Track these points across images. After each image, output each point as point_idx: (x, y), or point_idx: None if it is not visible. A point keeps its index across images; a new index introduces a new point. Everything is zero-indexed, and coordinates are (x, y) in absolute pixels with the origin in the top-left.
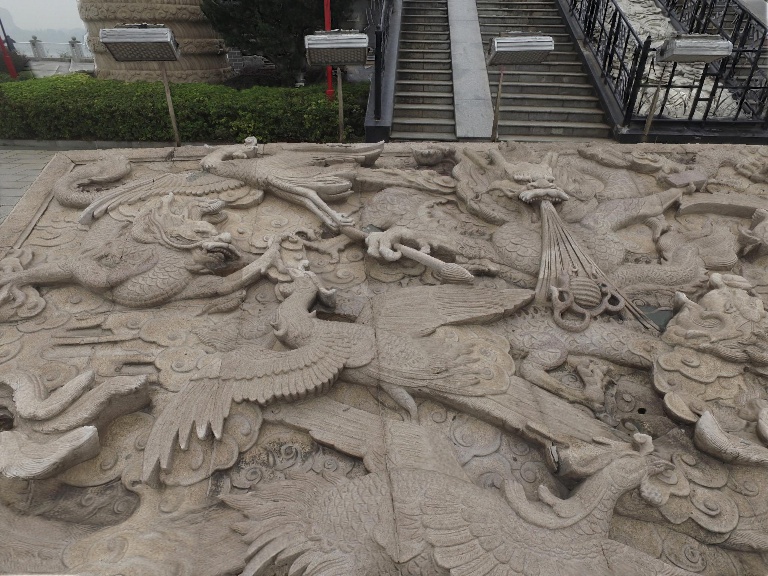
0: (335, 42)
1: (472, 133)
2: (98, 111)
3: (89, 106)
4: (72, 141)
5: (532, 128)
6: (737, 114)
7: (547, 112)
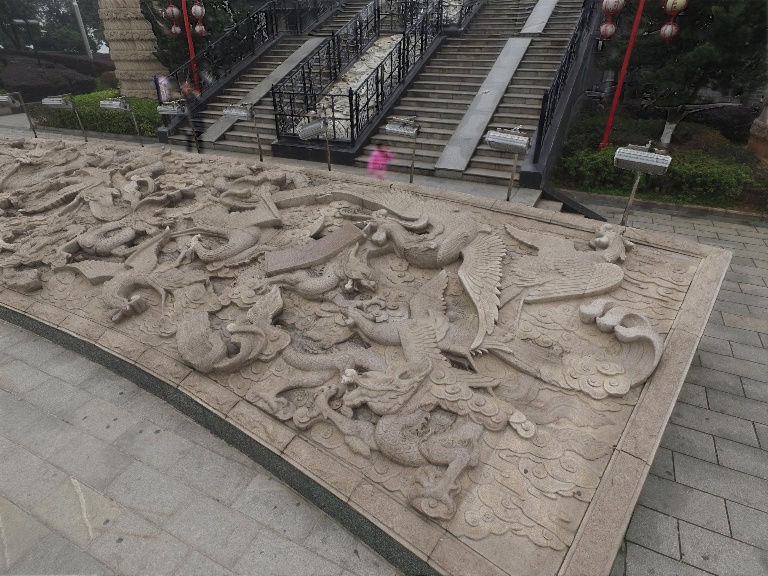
0: None
1: (204, 138)
2: (85, 114)
3: (84, 111)
4: (80, 130)
5: (243, 137)
6: (334, 135)
7: (261, 128)
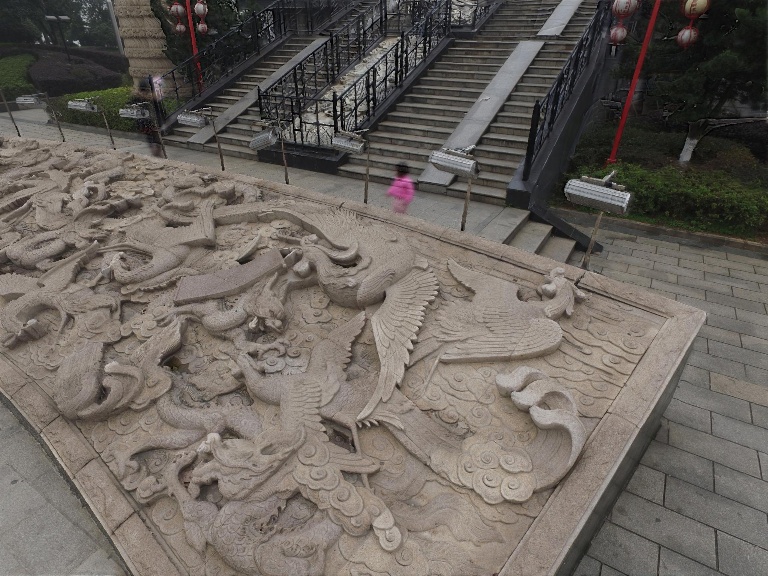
0: None
1: (194, 140)
2: None
3: None
4: (91, 127)
5: (233, 140)
6: (319, 142)
7: (252, 131)
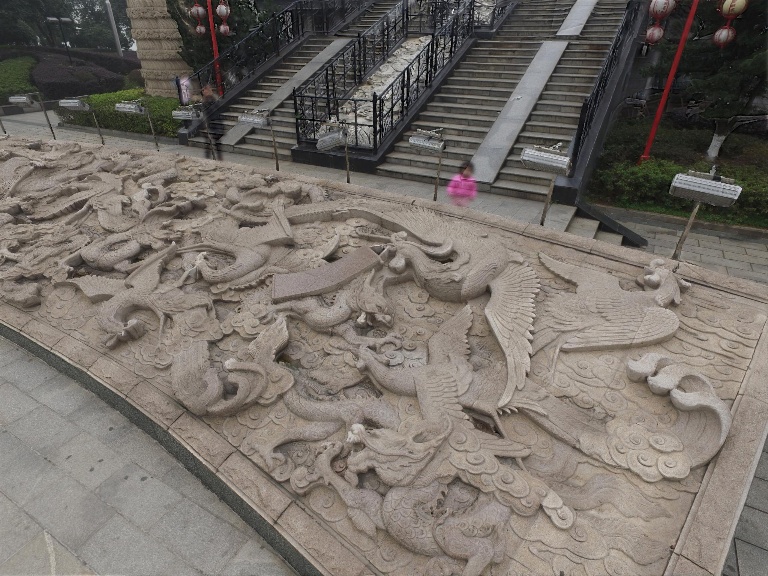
0: (17, 100)
1: (224, 141)
2: (110, 114)
3: (109, 110)
4: (105, 129)
5: (263, 141)
6: (356, 142)
7: (282, 131)
